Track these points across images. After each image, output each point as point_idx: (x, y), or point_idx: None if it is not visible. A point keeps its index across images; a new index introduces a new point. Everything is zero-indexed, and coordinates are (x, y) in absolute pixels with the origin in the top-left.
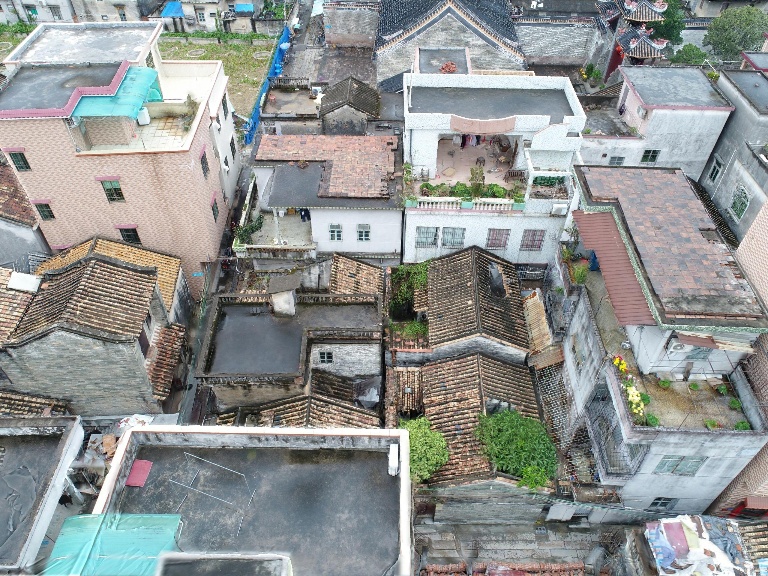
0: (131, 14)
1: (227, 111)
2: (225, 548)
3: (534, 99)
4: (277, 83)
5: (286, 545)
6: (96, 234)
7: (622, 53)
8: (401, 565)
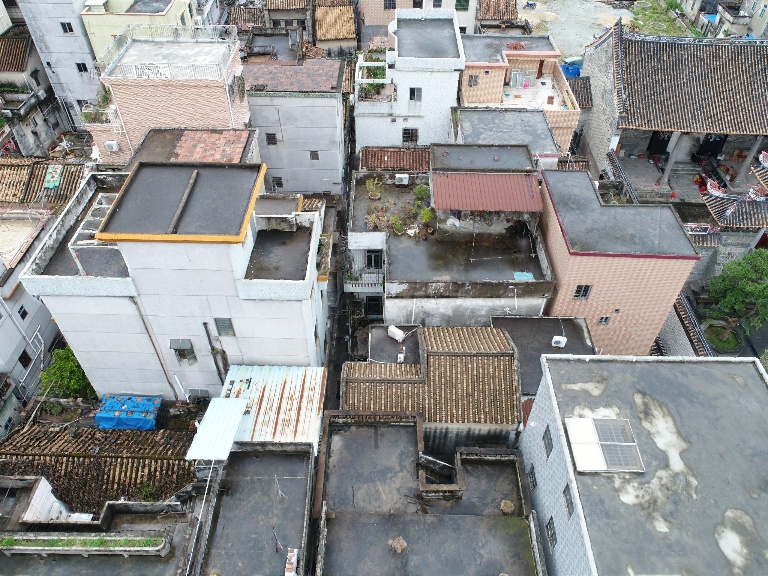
0: (697, 6)
1: (466, 8)
2: (145, 3)
3: (442, 56)
4: (526, 26)
5: (141, 10)
6: (362, 8)
7: None
8: (116, 13)
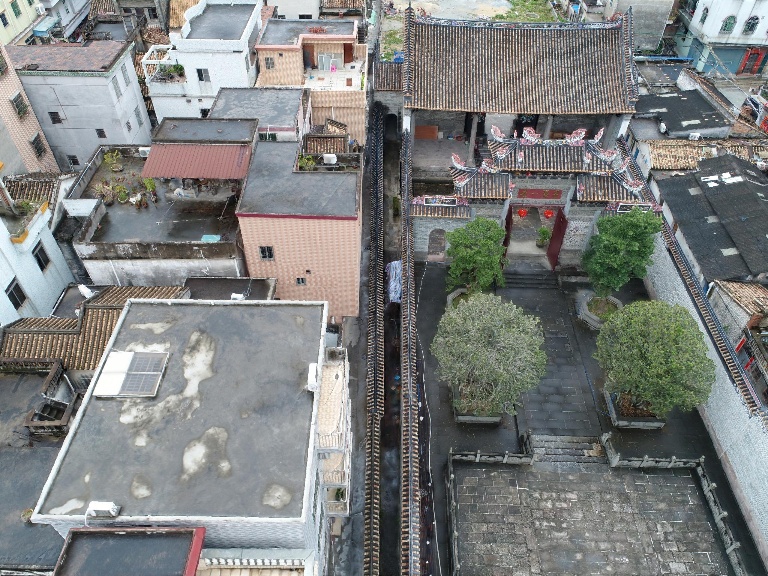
0: None
1: None
2: None
3: (229, 39)
4: None
5: None
6: None
7: (657, 285)
8: None
